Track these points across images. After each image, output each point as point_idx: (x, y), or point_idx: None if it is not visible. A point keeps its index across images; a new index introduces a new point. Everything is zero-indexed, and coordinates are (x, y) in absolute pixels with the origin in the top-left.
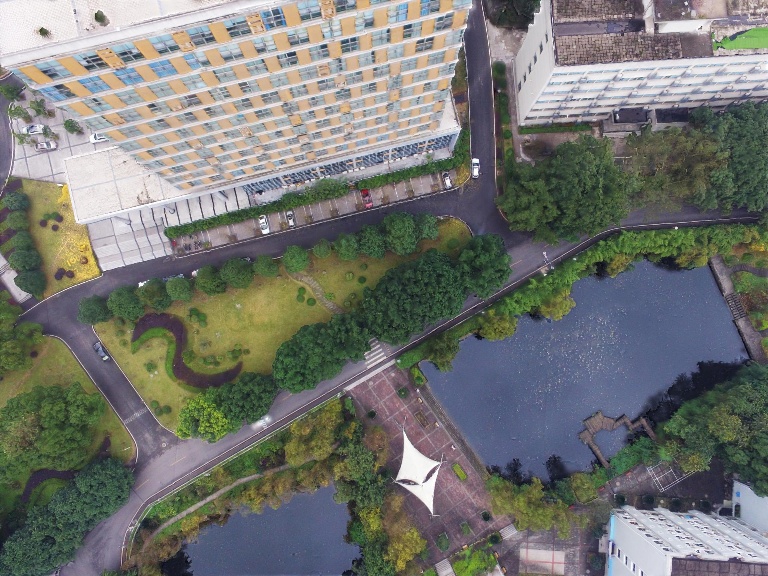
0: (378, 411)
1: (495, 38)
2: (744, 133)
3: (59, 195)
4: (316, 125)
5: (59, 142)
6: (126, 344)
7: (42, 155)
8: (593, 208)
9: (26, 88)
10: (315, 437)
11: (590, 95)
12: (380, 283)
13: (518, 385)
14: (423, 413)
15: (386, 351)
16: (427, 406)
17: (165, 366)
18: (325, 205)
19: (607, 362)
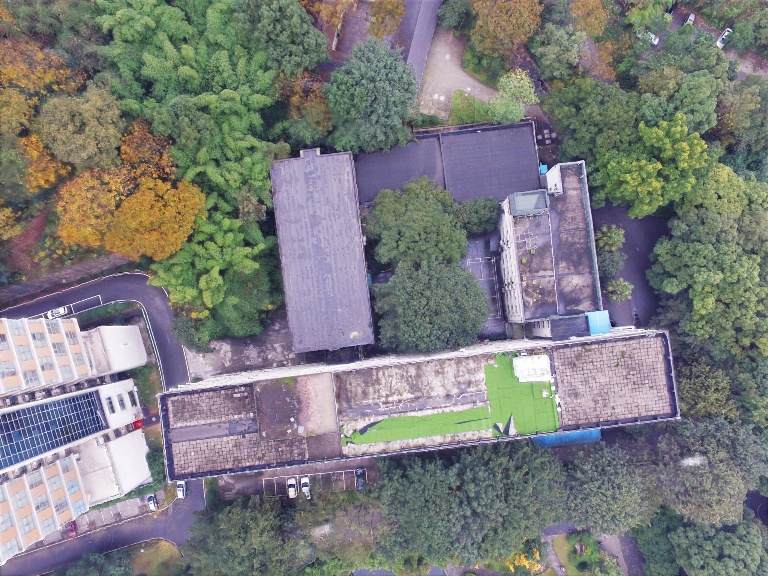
0: None
1: (192, 353)
2: (407, 499)
3: None
4: None
5: None
6: None
7: None
8: None
9: None
10: None
11: None
12: None
13: None
14: None
15: None
16: None
17: None
18: None
19: None
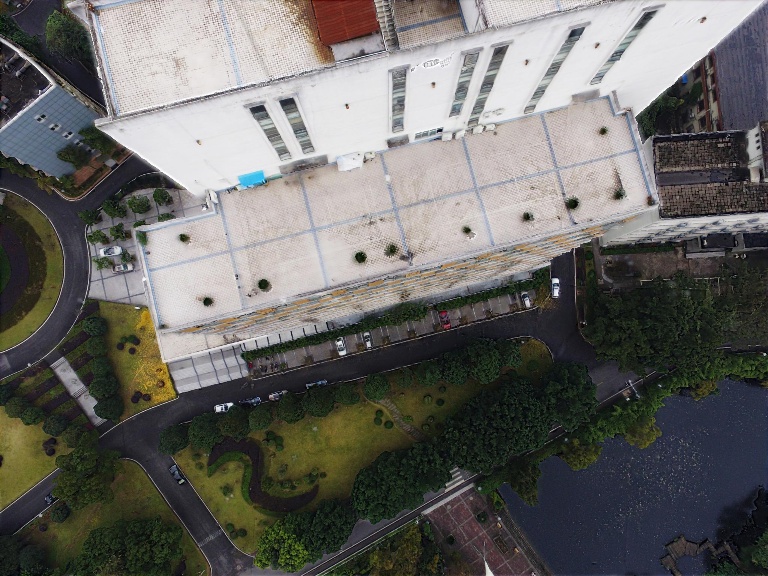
0: (456, 536)
1: None
2: None
3: (136, 317)
4: (421, 291)
5: (135, 263)
6: (202, 468)
7: (118, 276)
8: (690, 351)
9: (103, 209)
10: (396, 568)
11: (683, 230)
12: (462, 411)
13: (598, 508)
14: (502, 538)
15: (464, 474)
16: (506, 531)
17: (241, 490)
18: (402, 325)
19: (689, 484)
